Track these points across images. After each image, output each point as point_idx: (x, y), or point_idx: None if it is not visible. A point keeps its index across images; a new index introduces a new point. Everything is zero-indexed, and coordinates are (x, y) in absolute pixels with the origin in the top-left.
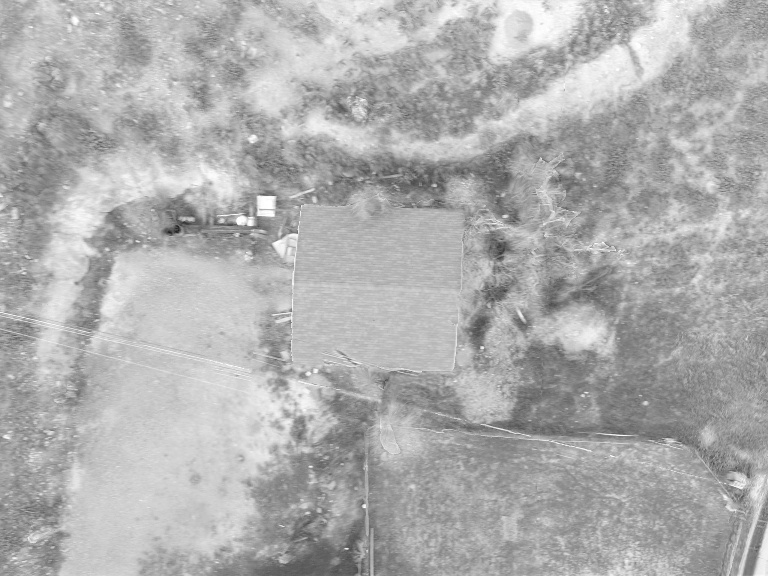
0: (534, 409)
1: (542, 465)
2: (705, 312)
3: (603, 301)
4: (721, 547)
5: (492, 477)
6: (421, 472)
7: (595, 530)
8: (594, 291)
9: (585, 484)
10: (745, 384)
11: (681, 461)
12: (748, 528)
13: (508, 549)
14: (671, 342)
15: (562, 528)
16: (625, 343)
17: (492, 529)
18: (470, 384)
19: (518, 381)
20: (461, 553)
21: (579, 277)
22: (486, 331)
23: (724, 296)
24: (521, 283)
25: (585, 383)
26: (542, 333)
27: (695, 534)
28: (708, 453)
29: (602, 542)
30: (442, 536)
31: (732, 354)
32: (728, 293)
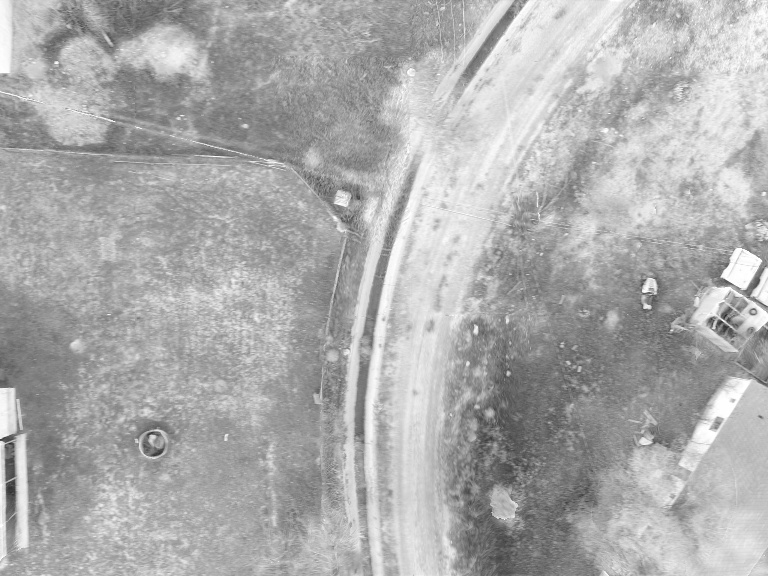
0: (128, 132)
1: (140, 187)
2: (301, 36)
3: (192, 24)
4: (334, 268)
5: (87, 199)
6: (12, 194)
7: (198, 250)
8: (181, 14)
9: (186, 206)
10: (346, 105)
11: (286, 183)
12: (366, 252)
13: (107, 269)
14: (267, 65)
15: (163, 248)
16: (220, 67)
17: (89, 249)
18: (47, 99)
19: (109, 104)
20: (57, 272)
21: (167, 2)
22: (62, 48)
23: (318, 18)
24: (103, 5)
25: (181, 107)
26: (131, 56)
27: (306, 255)
28: (314, 174)
29: (206, 262)
30: (36, 256)
31: (331, 76)
32: (323, 16)
